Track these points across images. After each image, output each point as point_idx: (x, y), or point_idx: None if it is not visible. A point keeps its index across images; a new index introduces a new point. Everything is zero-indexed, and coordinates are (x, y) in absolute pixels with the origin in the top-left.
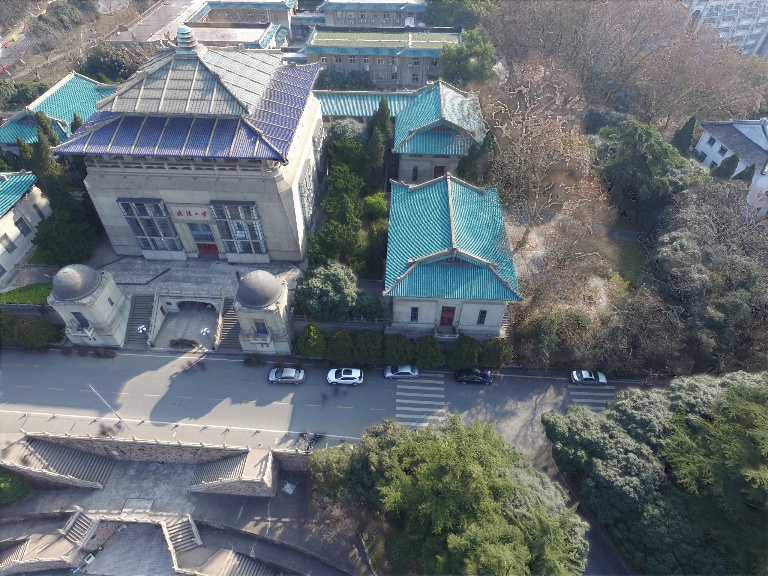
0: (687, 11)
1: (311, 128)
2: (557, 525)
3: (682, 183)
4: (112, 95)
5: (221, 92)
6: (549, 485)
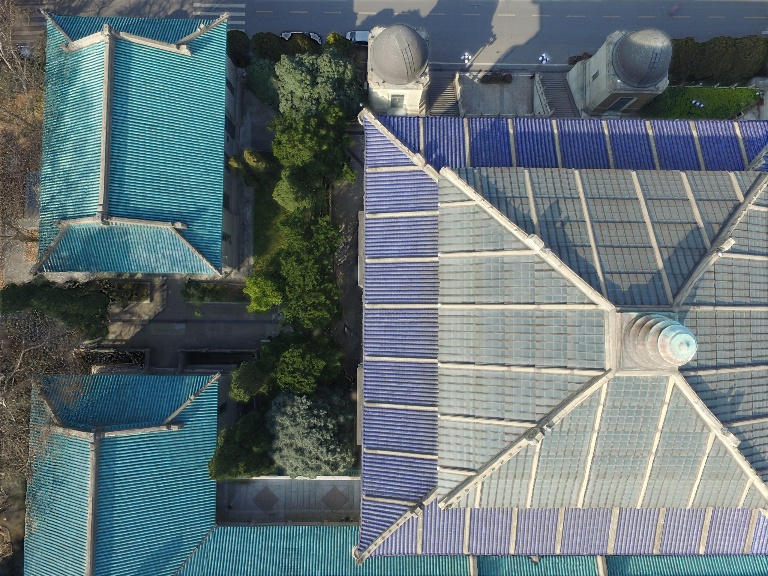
0: None
1: None
2: None
3: None
4: (753, 197)
5: (520, 217)
6: None
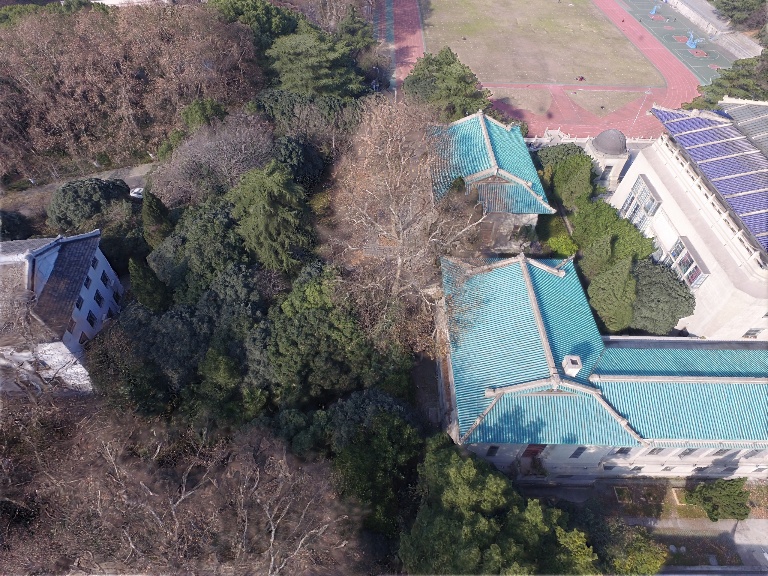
0: None
1: (694, 228)
2: (425, 58)
3: (228, 204)
4: None
5: None
6: (413, 99)
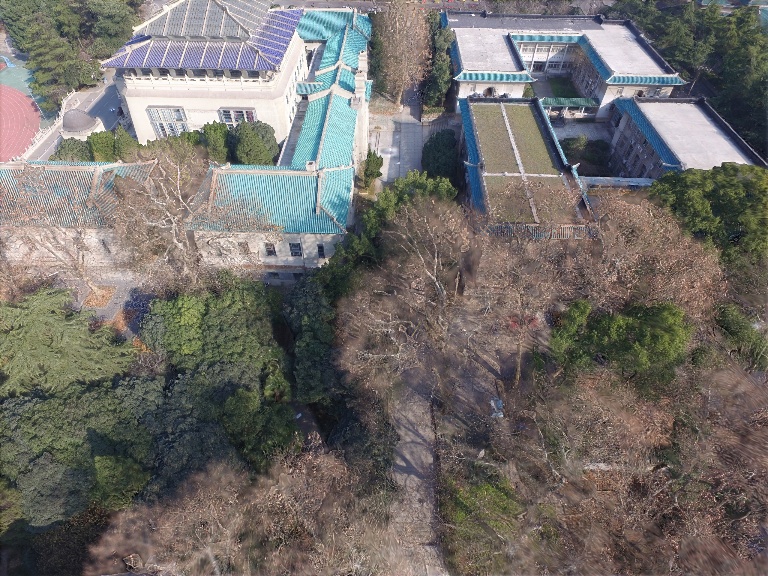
0: (525, 570)
1: (219, 99)
2: None
3: None
4: None
5: None
6: None
